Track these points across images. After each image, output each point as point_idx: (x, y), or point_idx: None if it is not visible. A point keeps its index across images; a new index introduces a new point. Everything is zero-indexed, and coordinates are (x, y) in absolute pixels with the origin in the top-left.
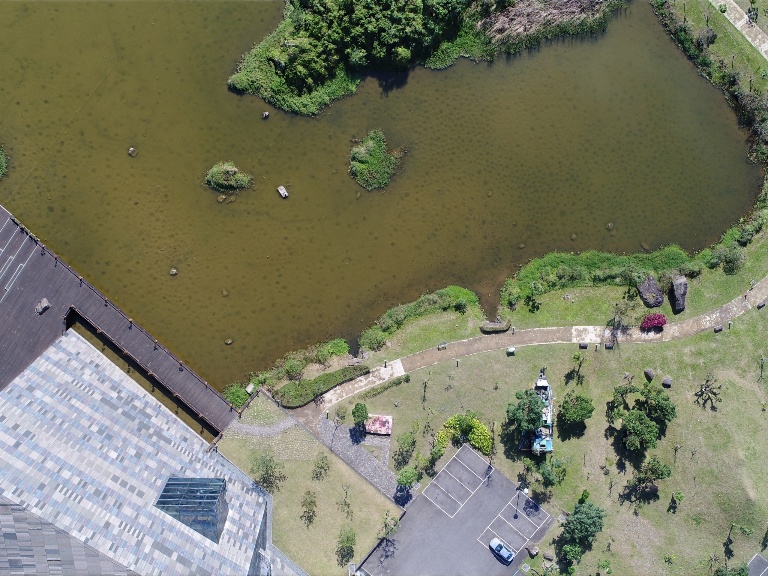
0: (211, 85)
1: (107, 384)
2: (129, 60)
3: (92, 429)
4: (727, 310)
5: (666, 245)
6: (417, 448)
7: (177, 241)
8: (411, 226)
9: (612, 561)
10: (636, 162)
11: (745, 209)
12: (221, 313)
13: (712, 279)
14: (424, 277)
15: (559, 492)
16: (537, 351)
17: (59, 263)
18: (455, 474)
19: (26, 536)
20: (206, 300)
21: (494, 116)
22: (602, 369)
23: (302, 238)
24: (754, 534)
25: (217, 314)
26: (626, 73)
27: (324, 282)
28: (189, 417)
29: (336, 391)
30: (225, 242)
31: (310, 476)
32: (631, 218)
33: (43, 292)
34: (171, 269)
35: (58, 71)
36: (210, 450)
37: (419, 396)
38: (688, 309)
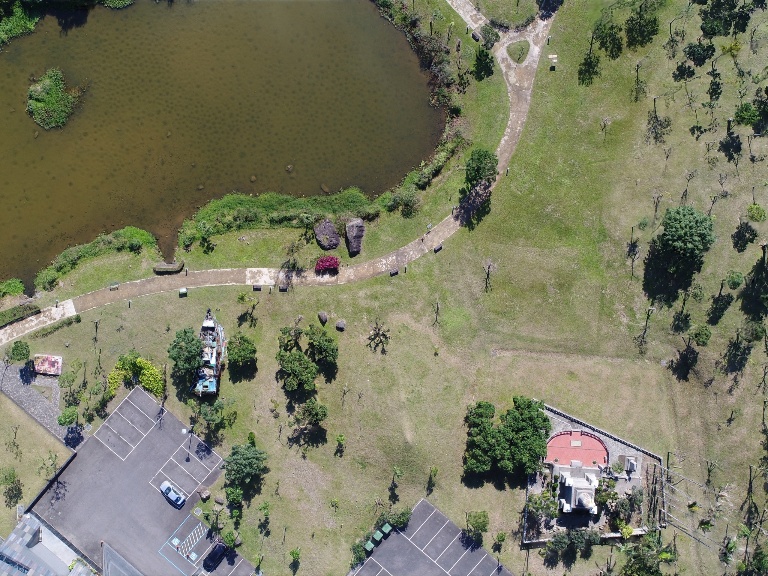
0: None
1: None
2: None
3: None
4: (403, 253)
5: (346, 188)
6: (88, 389)
7: None
8: (89, 166)
9: (280, 505)
10: (317, 104)
11: (427, 152)
12: None
13: (390, 222)
14: (102, 218)
15: (230, 435)
16: (210, 293)
17: None
18: (127, 416)
19: None
20: None
21: (174, 56)
22: (276, 311)
23: None
24: (417, 478)
25: None
26: (308, 14)
27: (1, 221)
28: None
29: (6, 331)
30: None
31: None
32: (311, 160)
33: None
34: None
35: None
36: None
37: (90, 337)
38: (364, 252)
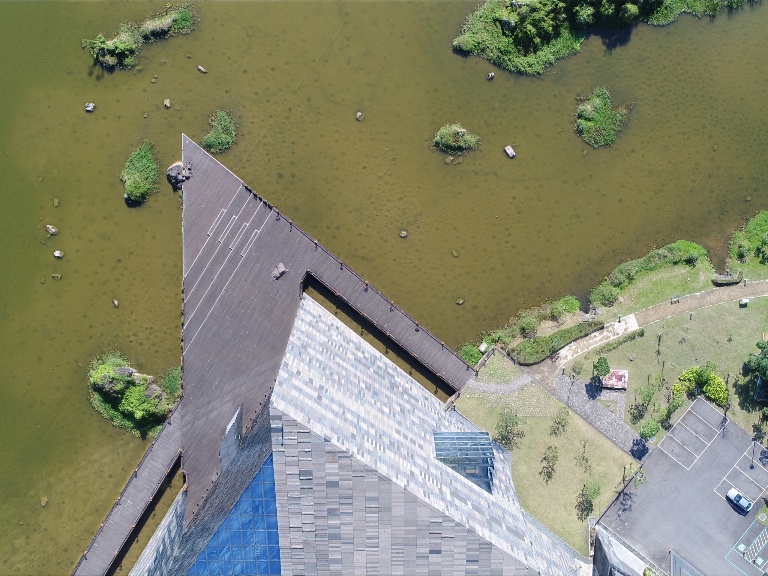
0: (435, 48)
1: (352, 345)
2: (354, 25)
3: (361, 386)
4: None
5: None
6: (652, 401)
7: (406, 204)
8: (638, 182)
9: None
10: None
11: None
12: (452, 274)
13: None
14: (652, 232)
15: None
16: None
17: (294, 228)
18: (690, 426)
19: (348, 484)
20: (436, 261)
21: (717, 70)
22: None
23: (530, 197)
24: None
25: (448, 275)
26: None
27: (553, 240)
28: (423, 377)
29: (571, 347)
30: (454, 203)
31: (548, 432)
32: None
33: (279, 257)
34: (401, 231)
35: (284, 38)
36: (448, 409)
37: (653, 350)
38: None
